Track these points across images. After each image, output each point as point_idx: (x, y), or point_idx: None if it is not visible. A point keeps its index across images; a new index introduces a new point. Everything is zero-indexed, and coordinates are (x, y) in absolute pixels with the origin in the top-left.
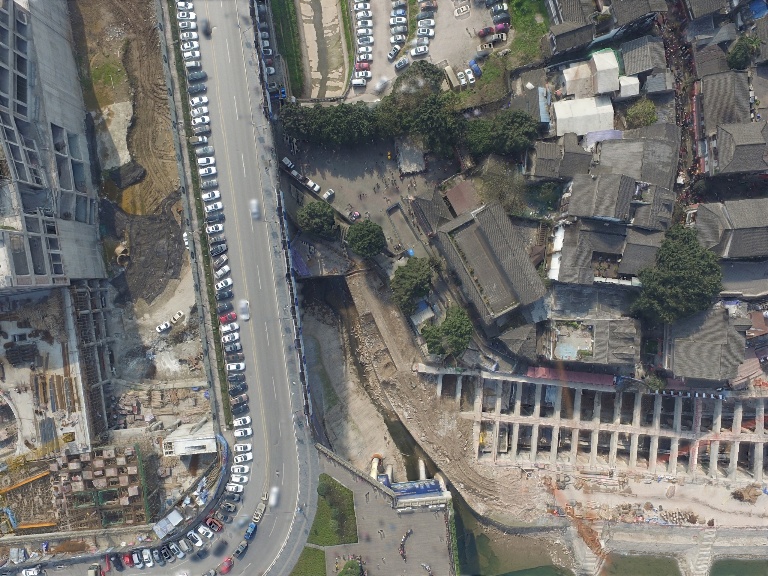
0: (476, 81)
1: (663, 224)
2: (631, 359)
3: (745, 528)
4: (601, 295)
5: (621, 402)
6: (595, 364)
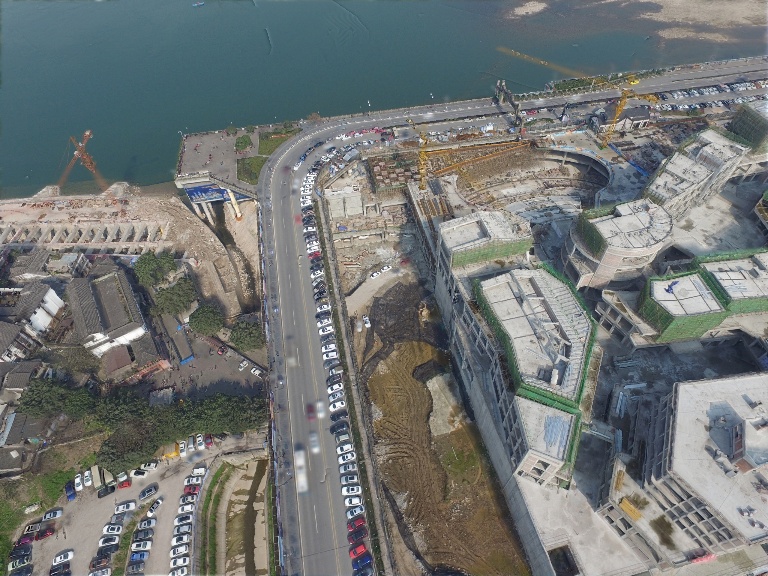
0: None
1: None
2: None
3: (3, 205)
4: None
5: None
6: None
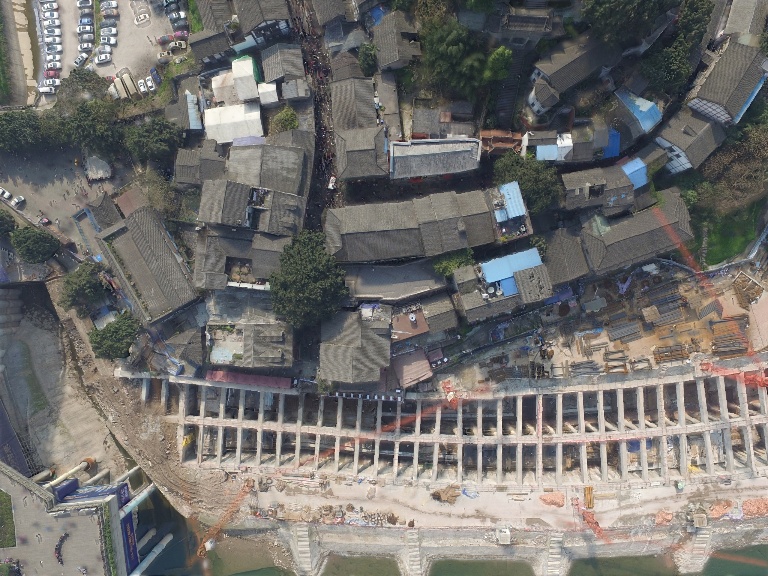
0: (158, 88)
1: (289, 229)
2: (281, 362)
3: (446, 529)
4: (253, 299)
5: (322, 405)
6: (275, 367)
